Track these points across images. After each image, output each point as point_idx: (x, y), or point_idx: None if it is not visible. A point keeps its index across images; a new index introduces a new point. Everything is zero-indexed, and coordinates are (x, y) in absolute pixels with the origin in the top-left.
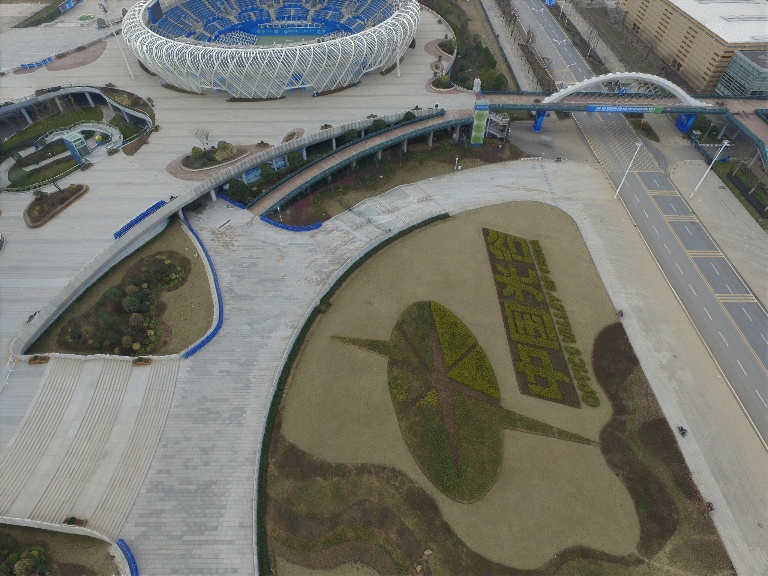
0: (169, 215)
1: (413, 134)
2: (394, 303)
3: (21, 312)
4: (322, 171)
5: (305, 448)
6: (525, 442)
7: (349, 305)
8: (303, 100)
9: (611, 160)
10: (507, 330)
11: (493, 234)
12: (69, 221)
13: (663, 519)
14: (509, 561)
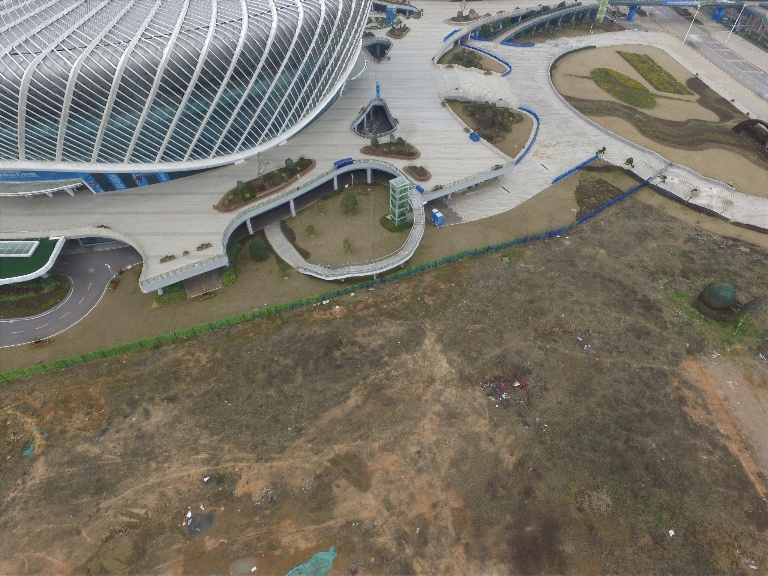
0: (458, 38)
1: (567, 13)
2: (586, 68)
3: (425, 58)
4: (524, 26)
5: (573, 96)
6: (665, 100)
7: (565, 68)
8: (494, 1)
9: (677, 31)
10: (644, 77)
11: (623, 52)
12: (413, 37)
13: (728, 115)
14: (669, 119)
